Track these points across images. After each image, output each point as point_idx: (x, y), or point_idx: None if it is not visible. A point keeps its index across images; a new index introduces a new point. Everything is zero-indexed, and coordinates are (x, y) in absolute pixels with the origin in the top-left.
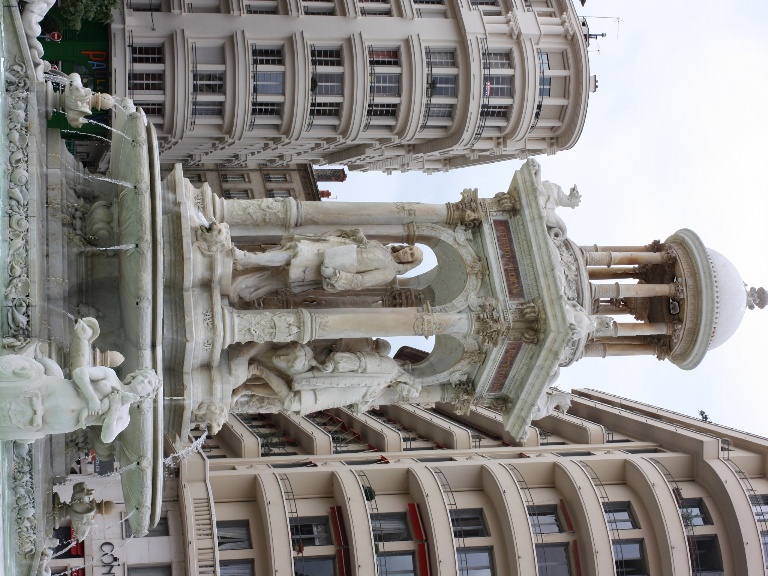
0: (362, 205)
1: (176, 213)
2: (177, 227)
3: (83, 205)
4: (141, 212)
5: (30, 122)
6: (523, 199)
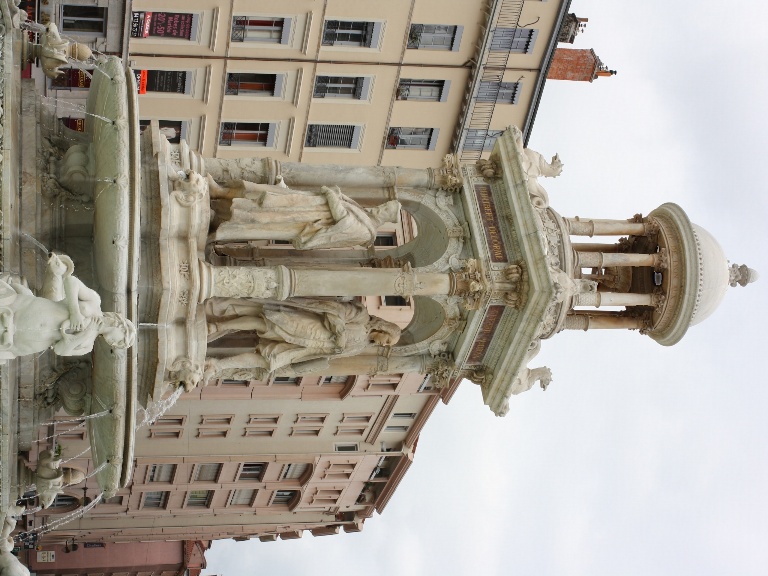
0: (359, 292)
1: (152, 362)
2: (151, 372)
3: (56, 370)
4: (108, 496)
5: (3, 426)
6: (526, 315)
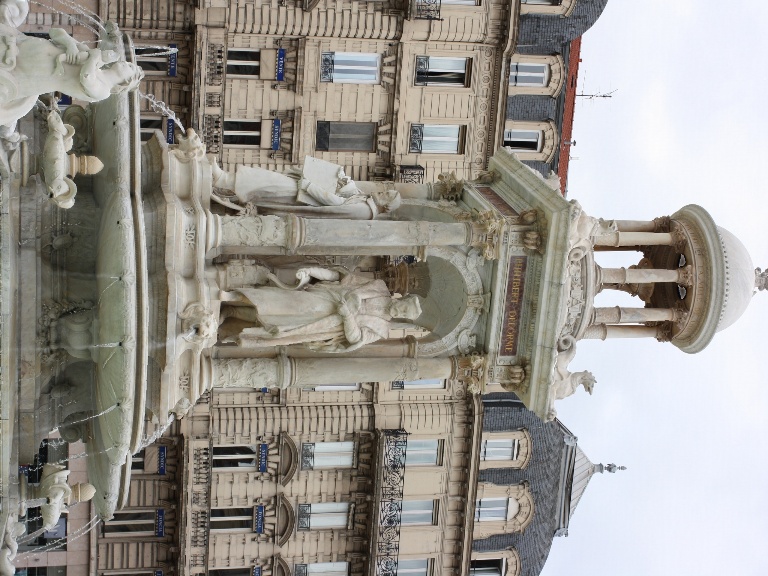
0: None
1: None
2: None
3: None
4: None
5: None
6: None
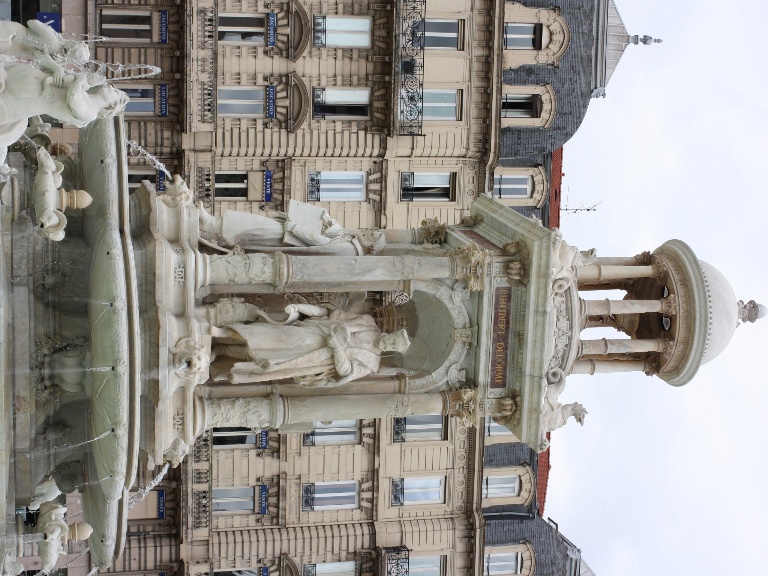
0: None
1: None
2: None
3: (49, 476)
4: None
5: None
6: None
